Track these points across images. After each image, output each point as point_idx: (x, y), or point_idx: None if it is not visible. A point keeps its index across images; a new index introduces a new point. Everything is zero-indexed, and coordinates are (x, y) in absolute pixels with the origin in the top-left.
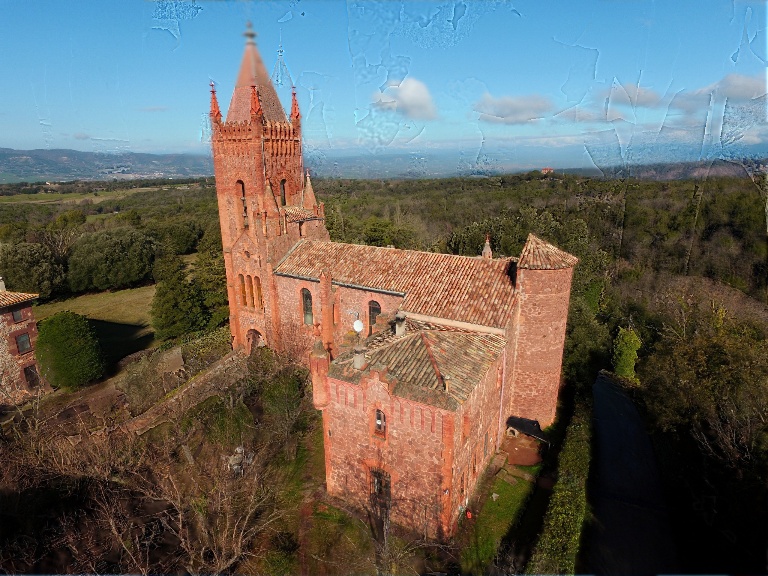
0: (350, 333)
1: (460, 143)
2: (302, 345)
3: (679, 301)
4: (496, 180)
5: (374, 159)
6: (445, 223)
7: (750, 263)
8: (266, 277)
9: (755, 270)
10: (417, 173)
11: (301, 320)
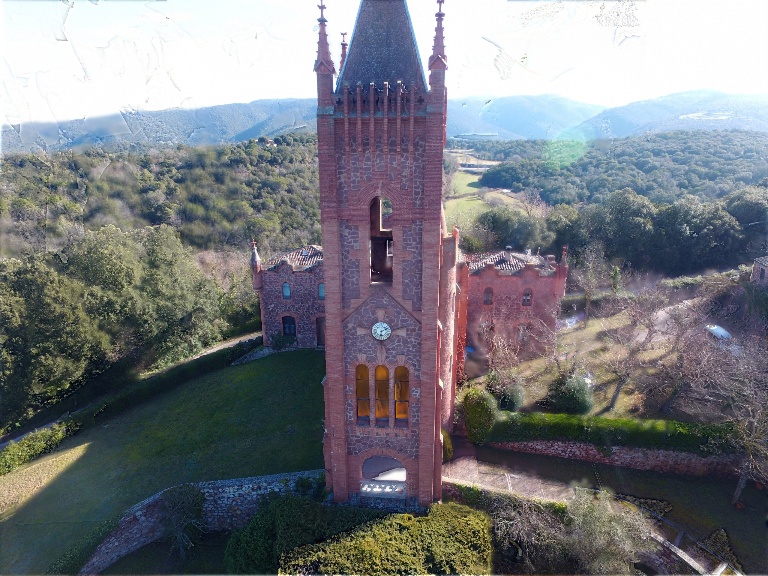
0: (530, 263)
1: None
2: None
3: None
4: None
5: (649, 151)
6: None
7: None
8: (454, 317)
9: None
10: None
11: None
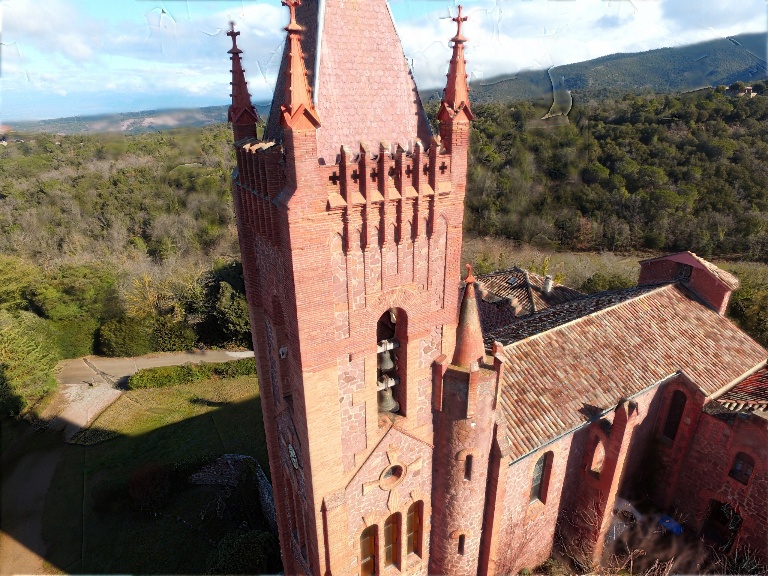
0: None
1: (80, 112)
2: (521, 544)
3: (479, 261)
4: (217, 168)
5: None
6: (82, 236)
7: (466, 215)
8: (482, 486)
9: (469, 220)
10: (32, 167)
11: (527, 507)
